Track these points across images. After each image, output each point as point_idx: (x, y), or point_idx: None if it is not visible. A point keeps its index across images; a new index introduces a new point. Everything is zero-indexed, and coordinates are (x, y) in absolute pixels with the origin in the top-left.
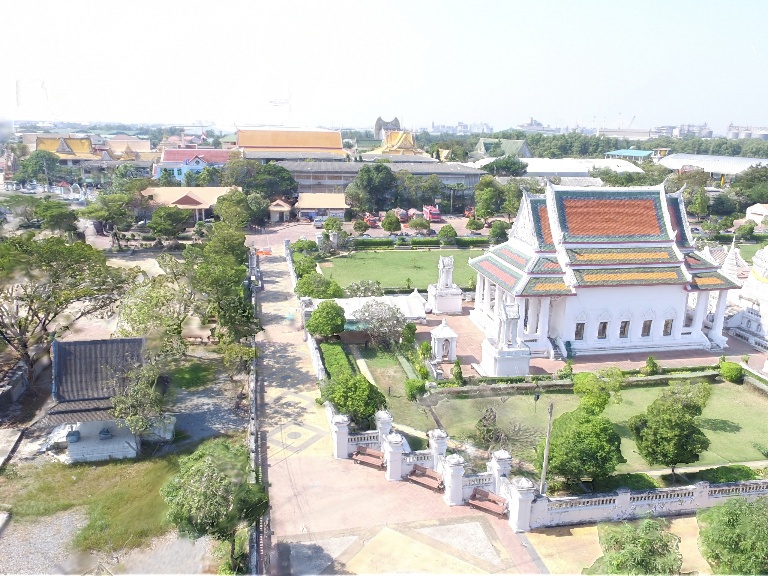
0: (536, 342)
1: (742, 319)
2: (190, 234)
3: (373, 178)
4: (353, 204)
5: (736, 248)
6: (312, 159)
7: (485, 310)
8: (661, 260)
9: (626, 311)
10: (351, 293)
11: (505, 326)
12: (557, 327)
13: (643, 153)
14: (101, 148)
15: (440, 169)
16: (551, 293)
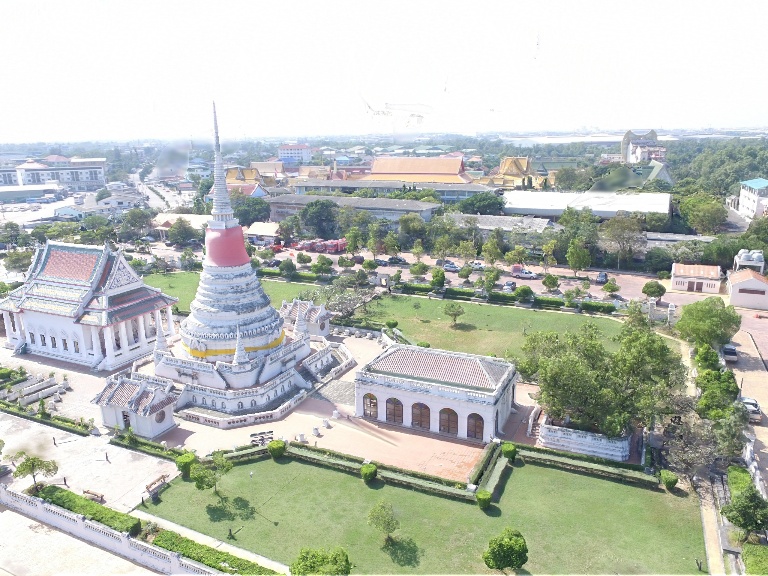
0: None
1: None
2: (134, 248)
3: None
4: (281, 233)
5: None
6: (370, 188)
7: None
8: None
9: (50, 330)
10: (2, 295)
11: None
12: None
13: (759, 185)
14: (266, 175)
15: (387, 205)
16: (8, 309)
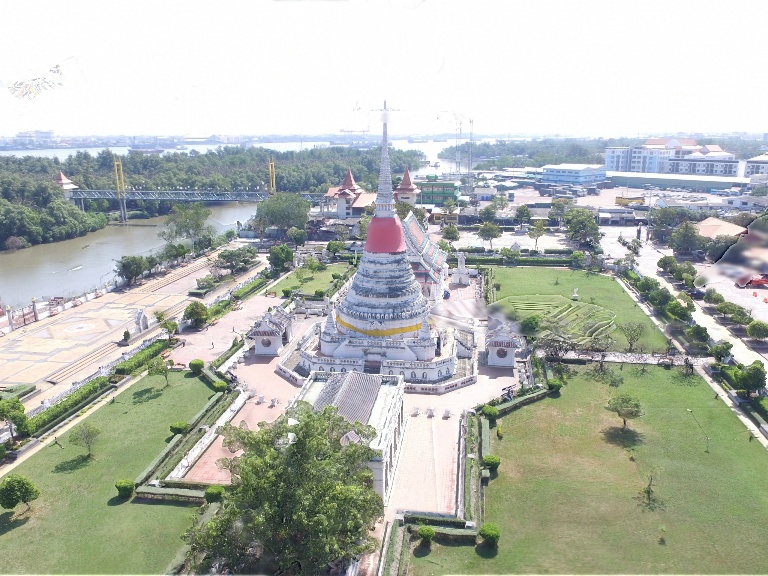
0: None
1: None
2: None
3: None
4: None
5: None
6: None
7: None
8: None
9: None
10: None
11: None
12: None
13: None
14: None
15: None
16: None
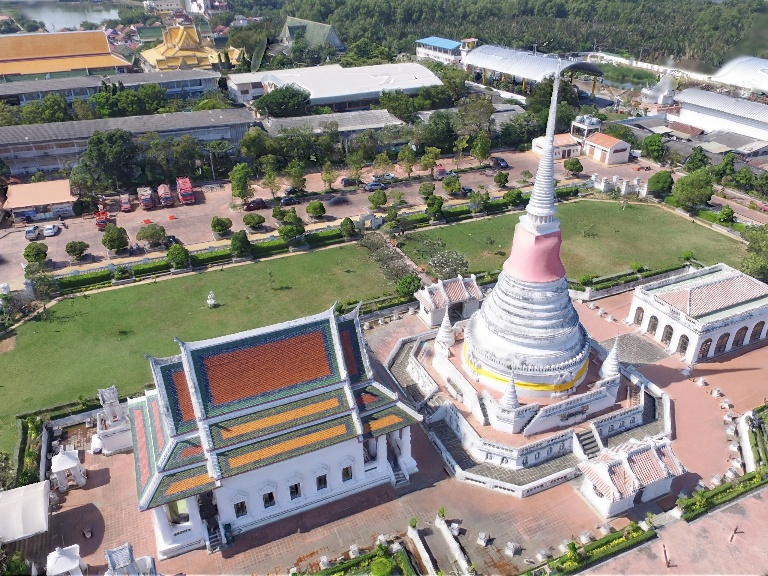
0: (190, 531)
1: (446, 412)
2: None
3: (105, 153)
4: (81, 193)
5: (472, 274)
6: (55, 93)
7: None
8: (328, 413)
9: (292, 477)
10: None
11: (116, 574)
12: None
13: (451, 45)
14: None
15: (198, 121)
16: (188, 495)
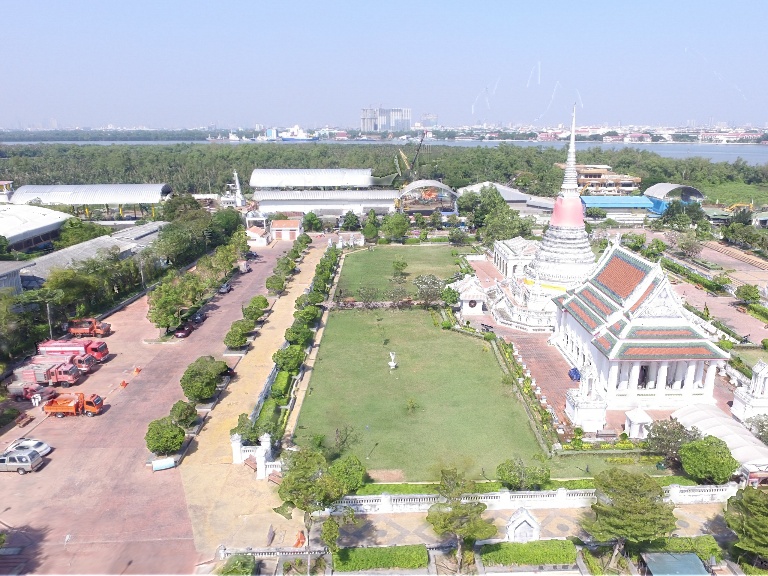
0: None
1: None
2: None
3: None
4: None
5: None
6: None
7: (637, 392)
8: None
9: None
10: None
11: None
12: (683, 372)
13: None
14: None
15: None
16: None
